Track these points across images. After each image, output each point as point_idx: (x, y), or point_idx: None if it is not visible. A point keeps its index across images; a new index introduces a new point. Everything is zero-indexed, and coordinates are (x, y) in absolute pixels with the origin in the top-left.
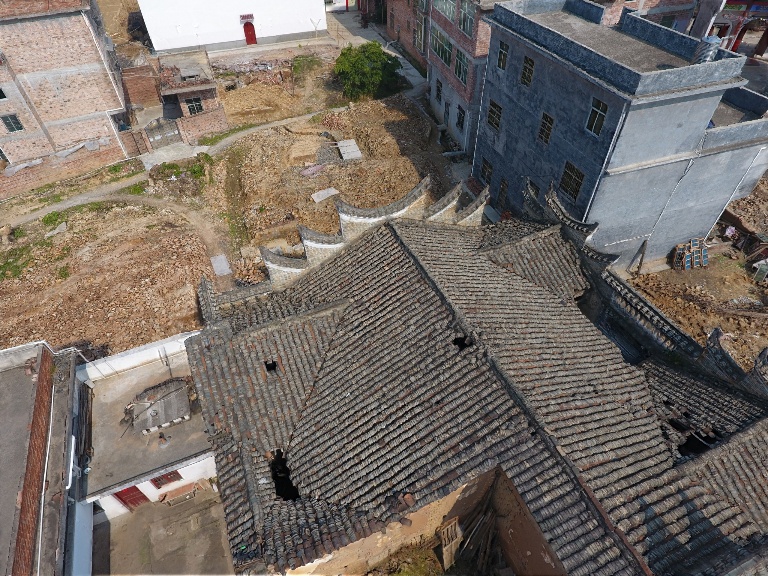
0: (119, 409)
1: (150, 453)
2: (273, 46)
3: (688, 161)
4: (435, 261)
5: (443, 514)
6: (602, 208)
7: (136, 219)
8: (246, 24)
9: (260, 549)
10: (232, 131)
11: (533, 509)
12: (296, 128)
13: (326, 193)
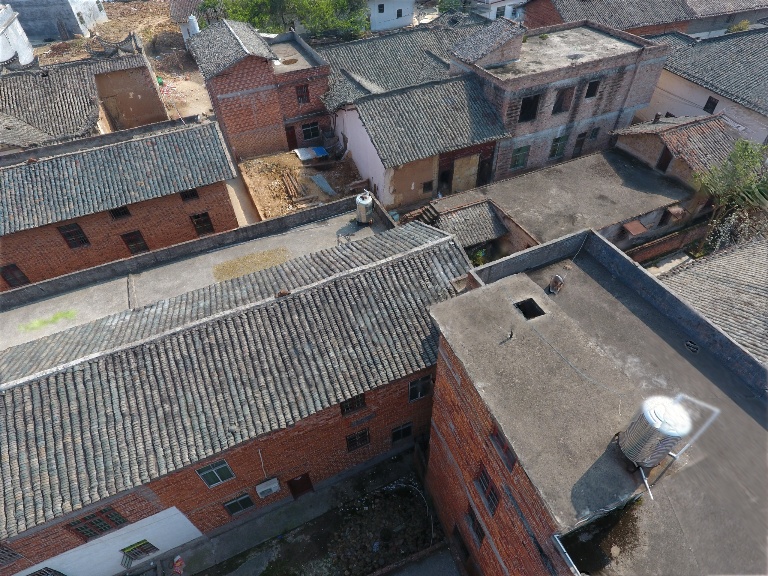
0: None
1: None
2: None
3: (3, 33)
4: None
5: (109, 127)
6: None
7: None
8: None
9: (88, 131)
10: None
11: (110, 71)
12: None
13: None
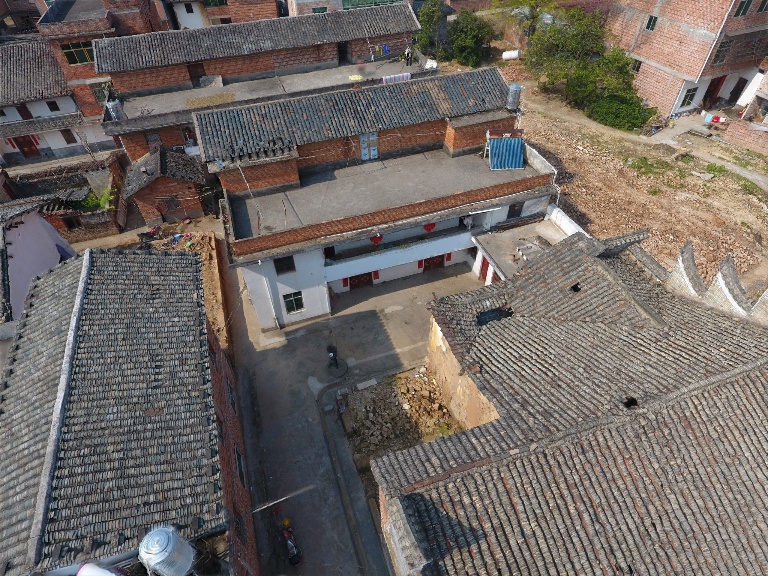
0: (532, 236)
1: (505, 257)
2: None
3: None
4: (760, 396)
5: None
6: None
7: (749, 213)
8: None
9: None
10: None
11: (467, 431)
12: None
13: None
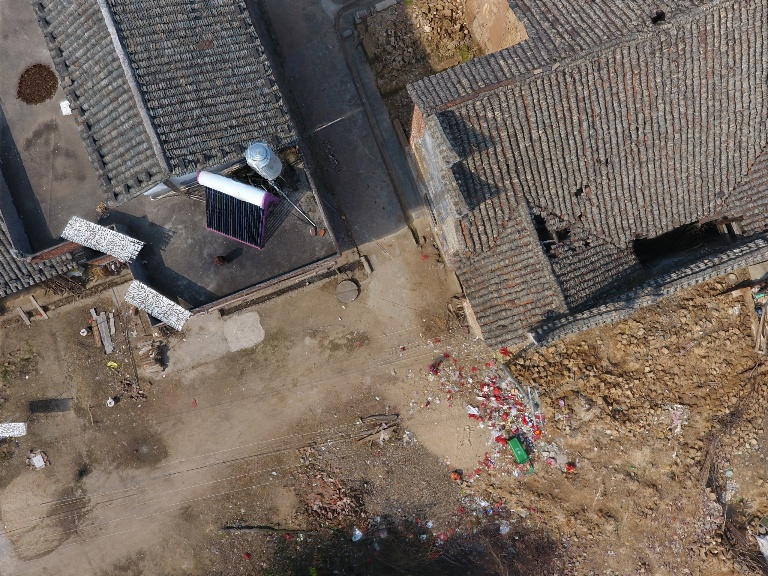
0: None
1: None
2: None
3: None
4: None
5: None
6: None
7: None
8: None
9: None
10: None
11: (496, 54)
12: None
13: None
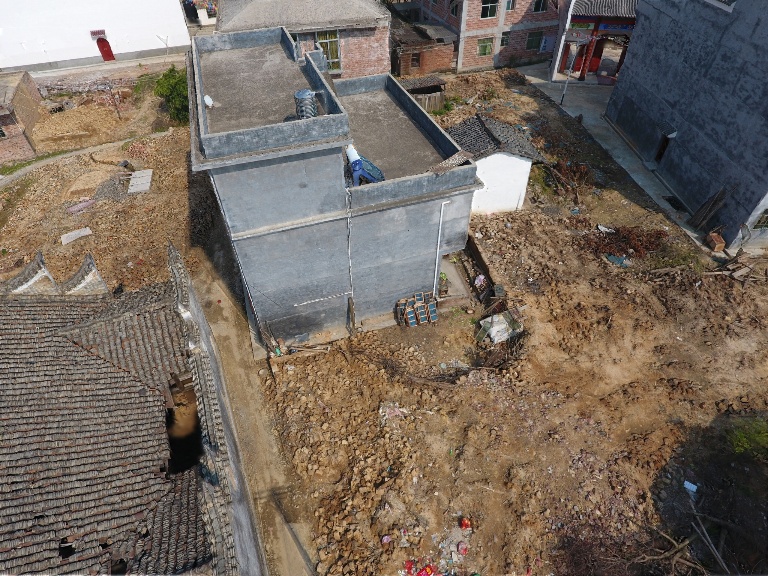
0: None
1: None
2: (132, 62)
3: (346, 220)
4: None
5: None
6: (258, 271)
7: None
8: (99, 40)
9: None
10: (39, 158)
11: None
12: (101, 156)
13: (77, 234)
